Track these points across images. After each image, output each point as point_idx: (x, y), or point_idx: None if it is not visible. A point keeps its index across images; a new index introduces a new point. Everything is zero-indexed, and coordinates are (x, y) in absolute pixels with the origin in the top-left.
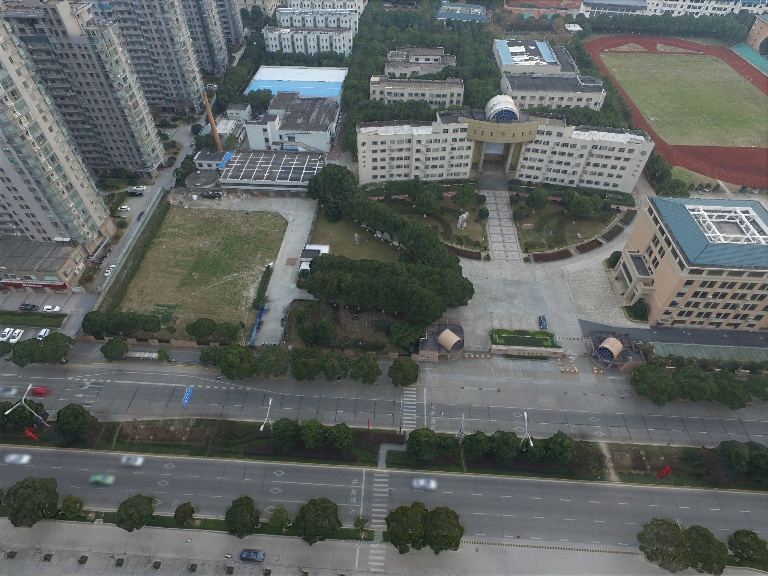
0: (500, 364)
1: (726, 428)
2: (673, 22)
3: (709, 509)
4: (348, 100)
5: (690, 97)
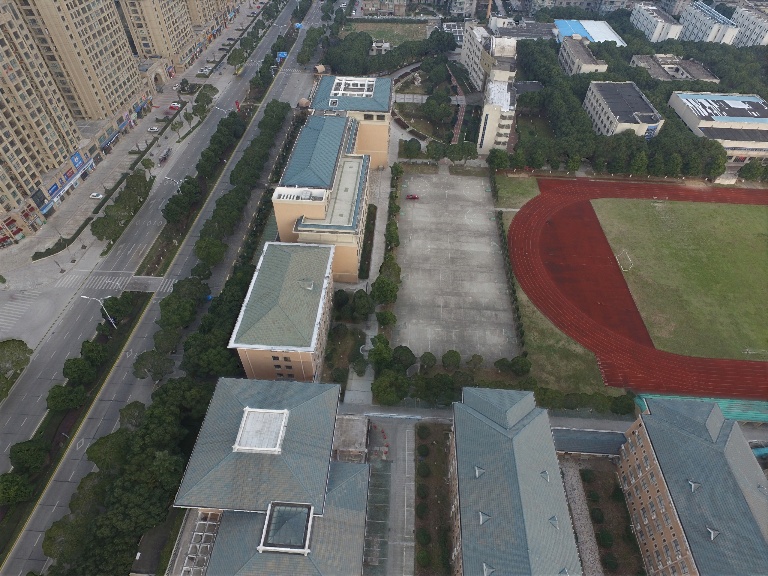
0: None
1: None
2: None
3: None
4: None
5: None
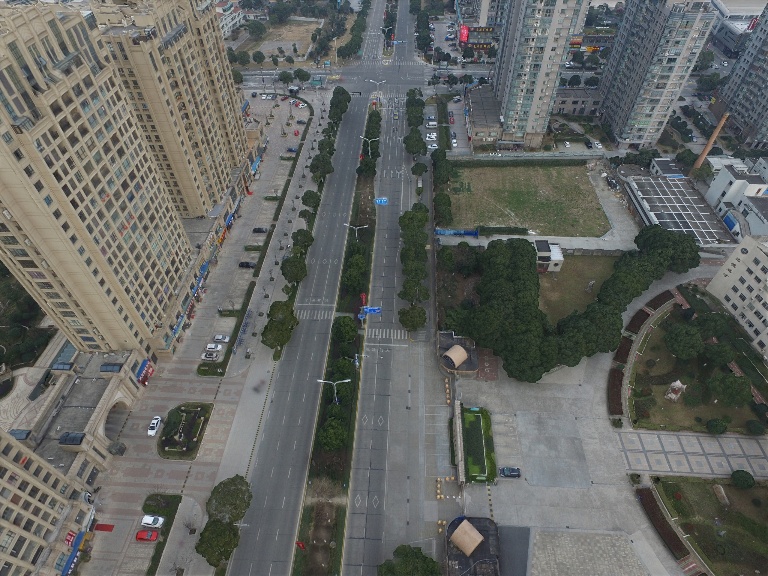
0: (441, 413)
1: None
2: None
3: None
4: None
5: None
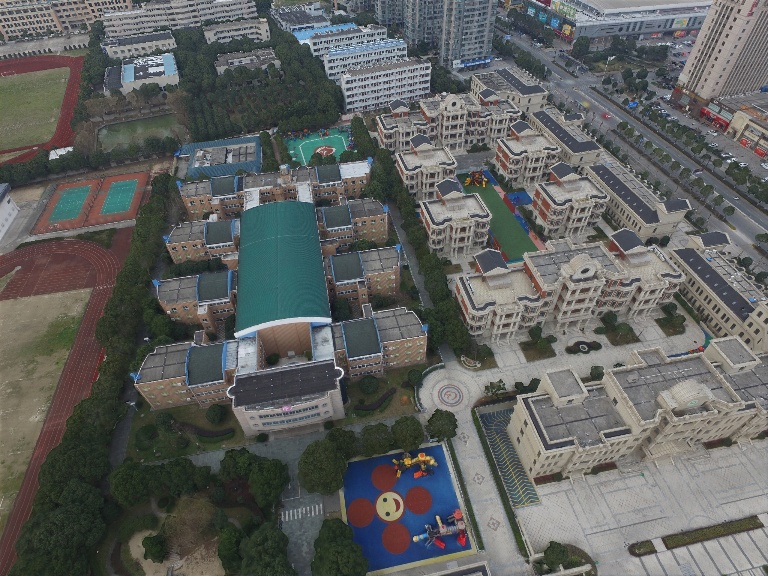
0: None
1: None
2: None
3: None
4: None
5: (6, 103)
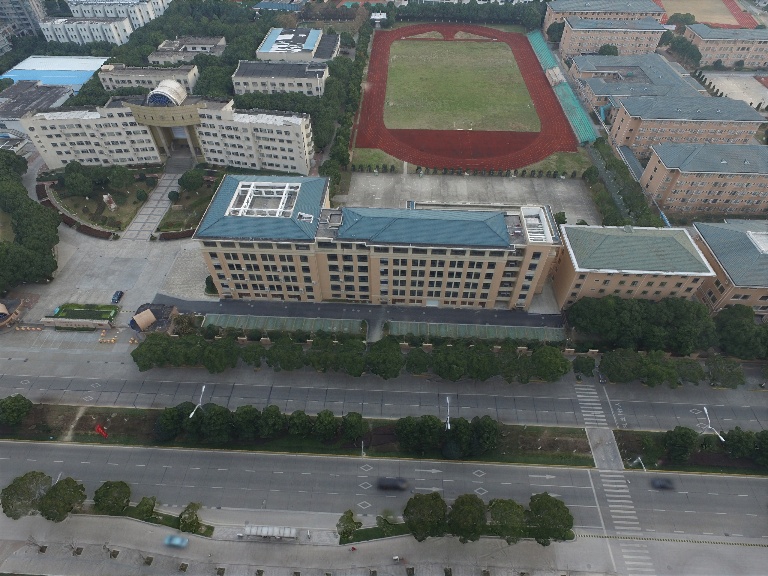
0: (46, 336)
1: (214, 392)
2: (476, 10)
3: (135, 465)
4: None
5: (446, 83)
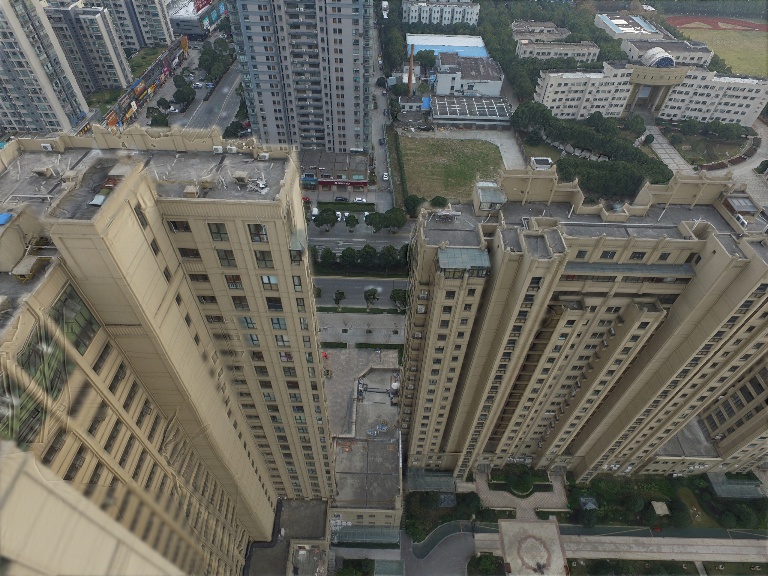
0: None
1: None
2: (729, 4)
3: None
4: (497, 60)
5: (763, 62)
